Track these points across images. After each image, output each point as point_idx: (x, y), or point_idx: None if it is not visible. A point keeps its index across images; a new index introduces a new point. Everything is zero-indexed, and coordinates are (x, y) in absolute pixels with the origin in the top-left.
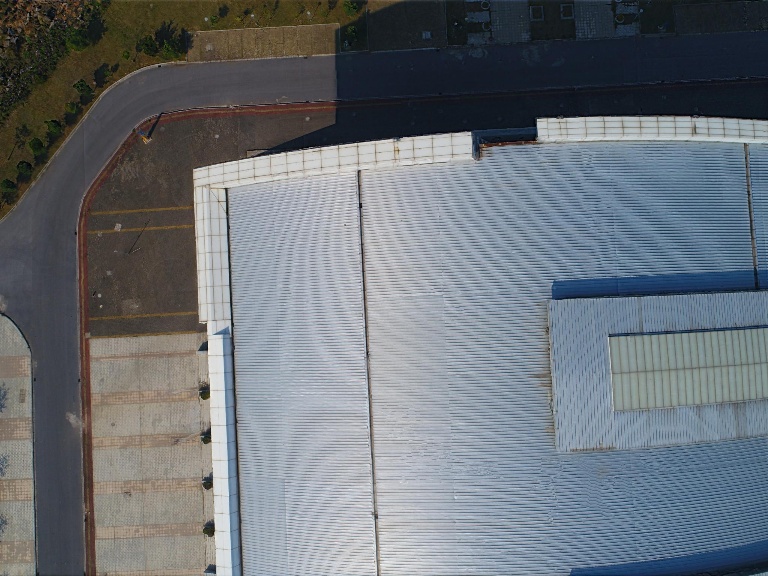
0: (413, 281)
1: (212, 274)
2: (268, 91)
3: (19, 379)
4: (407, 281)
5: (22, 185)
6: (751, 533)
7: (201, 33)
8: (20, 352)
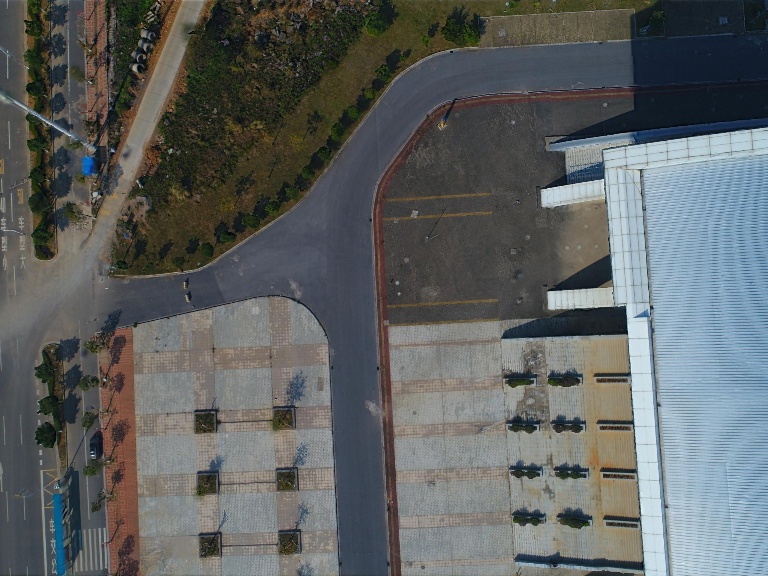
0: None
1: (631, 256)
2: (563, 77)
3: (317, 367)
4: None
5: (315, 171)
6: None
7: (493, 18)
8: (317, 340)
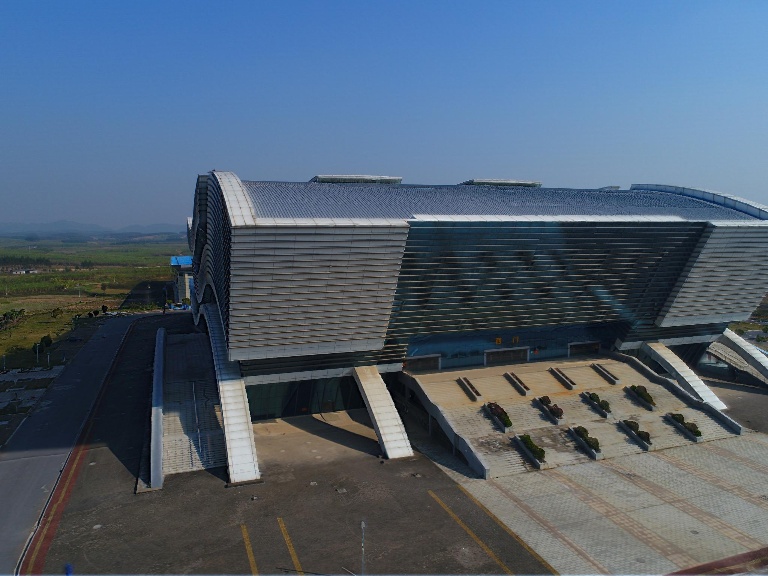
0: None
1: None
2: (23, 500)
3: None
4: None
5: None
6: None
7: None
8: None
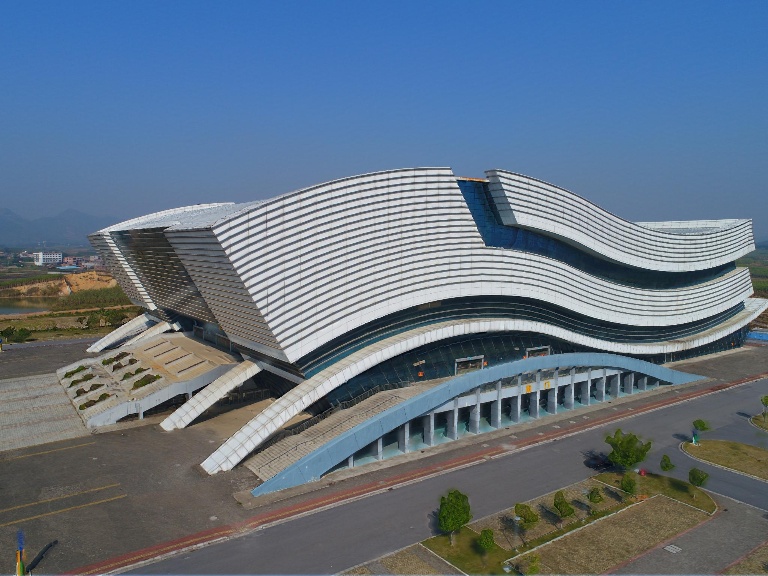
0: None
1: None
2: None
3: None
4: None
5: None
6: None
7: (44, 338)
8: None
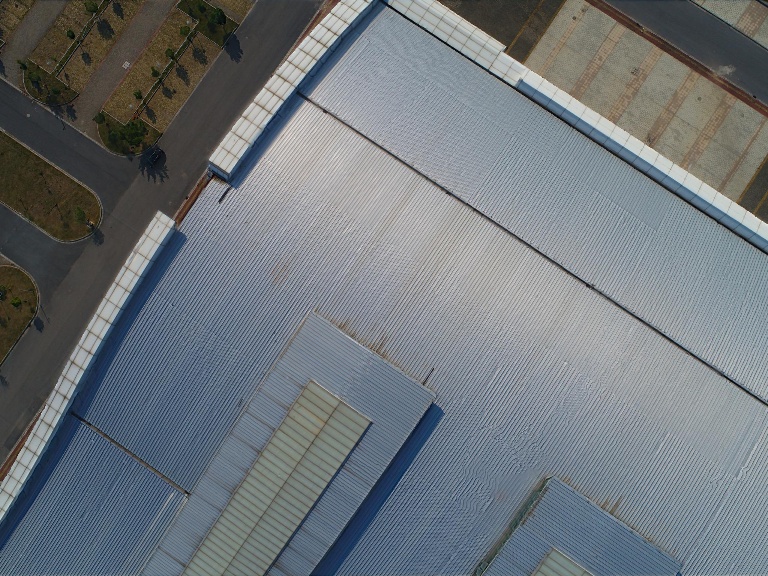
0: (764, 461)
1: None
2: None
3: None
4: (767, 456)
5: None
6: (348, 573)
7: None
8: None
